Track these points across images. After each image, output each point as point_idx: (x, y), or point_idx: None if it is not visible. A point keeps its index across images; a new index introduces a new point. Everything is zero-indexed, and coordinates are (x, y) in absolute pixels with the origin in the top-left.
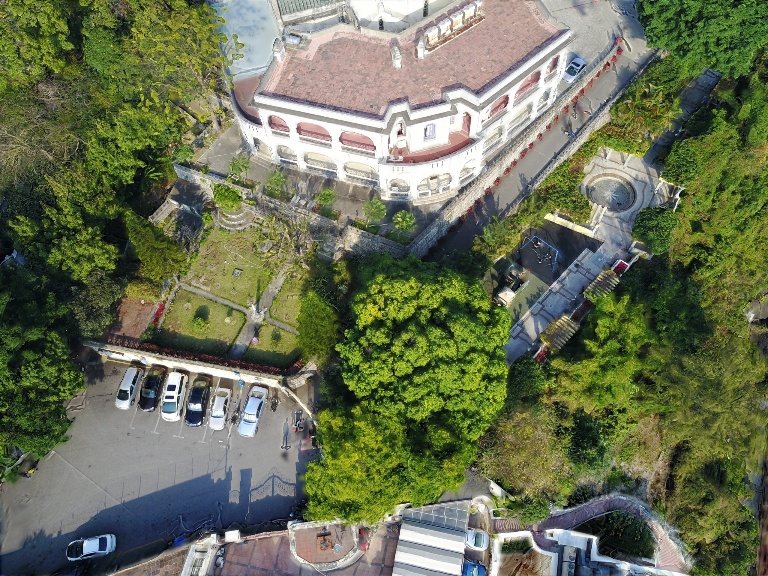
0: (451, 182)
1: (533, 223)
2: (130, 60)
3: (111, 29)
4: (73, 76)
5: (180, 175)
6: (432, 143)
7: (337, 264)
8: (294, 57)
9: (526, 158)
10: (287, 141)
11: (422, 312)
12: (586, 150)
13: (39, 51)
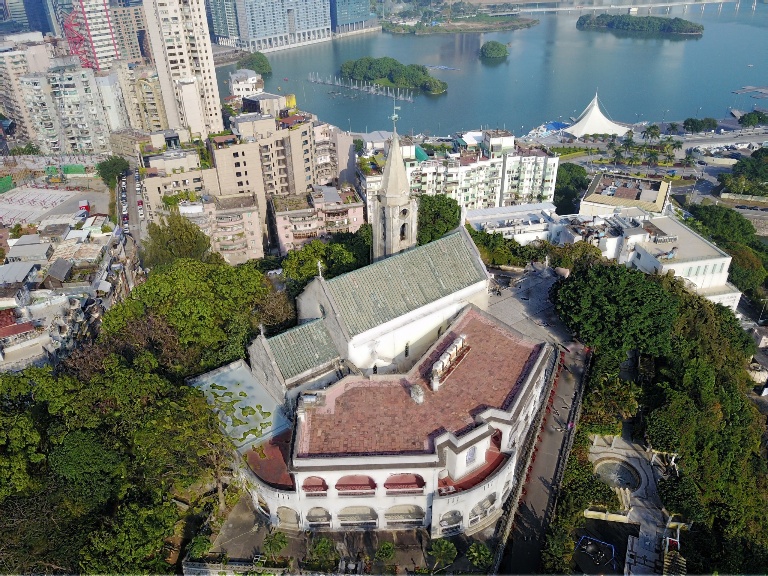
0: (496, 501)
1: (577, 523)
2: (108, 457)
3: (89, 429)
4: (30, 491)
5: (189, 575)
6: (472, 466)
7: None
8: (315, 414)
9: (536, 461)
10: (323, 501)
11: None
12: (580, 441)
13: (9, 470)
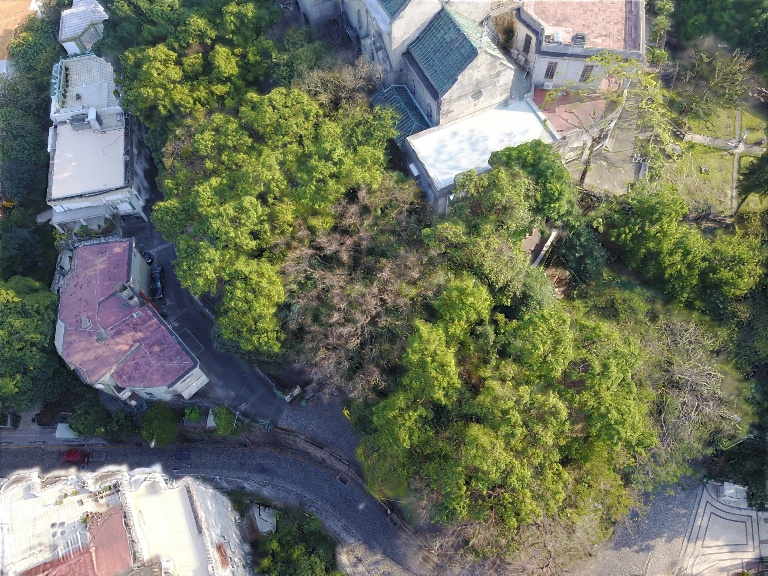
0: None
1: None
2: None
3: None
4: None
5: None
6: None
7: None
8: None
9: None
10: None
11: None
12: None
13: None
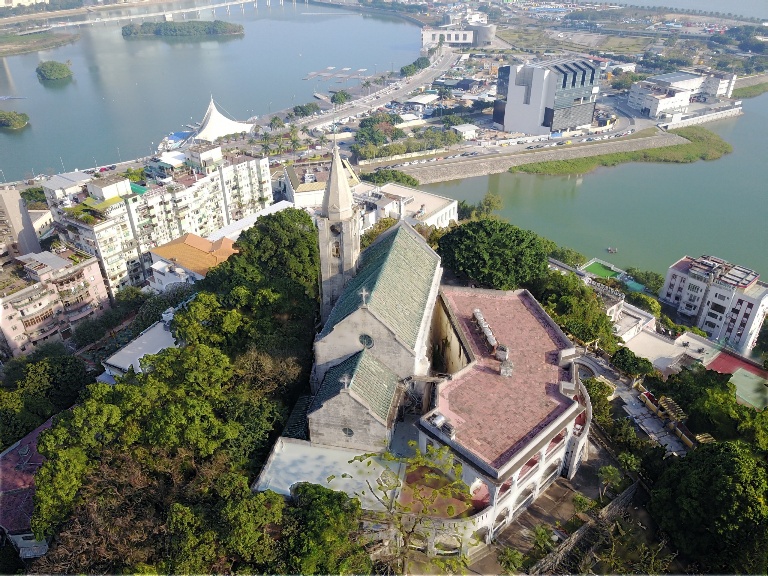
0: None
1: None
2: None
3: None
4: None
5: None
6: None
7: None
8: None
9: None
10: (508, 500)
11: (760, 472)
12: None
13: None
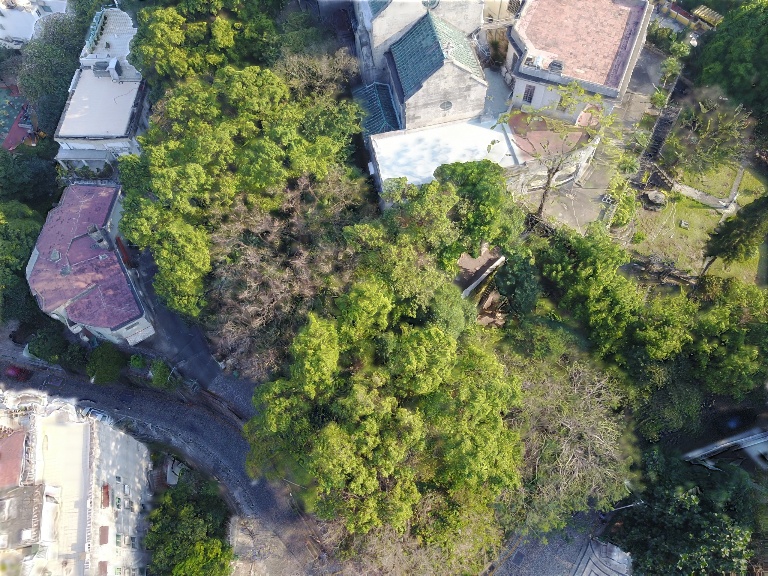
0: None
1: None
2: None
3: None
4: None
5: None
6: None
7: (670, 142)
8: None
9: None
10: None
11: None
12: None
13: None
